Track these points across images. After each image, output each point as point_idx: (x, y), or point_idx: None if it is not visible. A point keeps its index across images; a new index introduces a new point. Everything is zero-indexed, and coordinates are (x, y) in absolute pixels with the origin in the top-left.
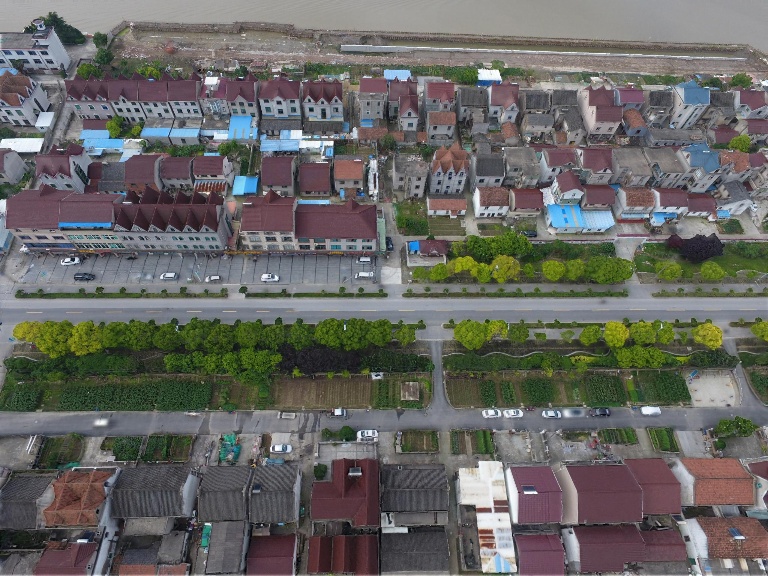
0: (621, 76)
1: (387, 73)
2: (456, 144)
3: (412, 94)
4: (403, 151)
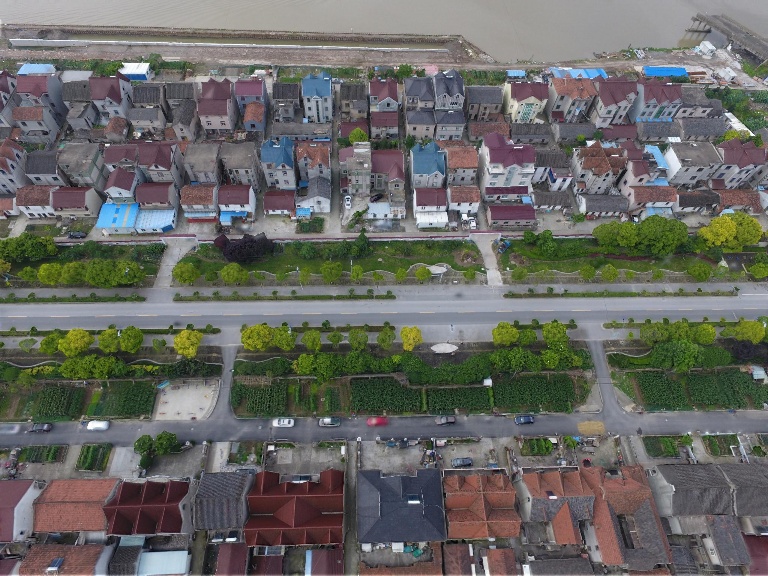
0: (294, 69)
1: (24, 67)
2: (5, 140)
3: (2, 88)
4: None
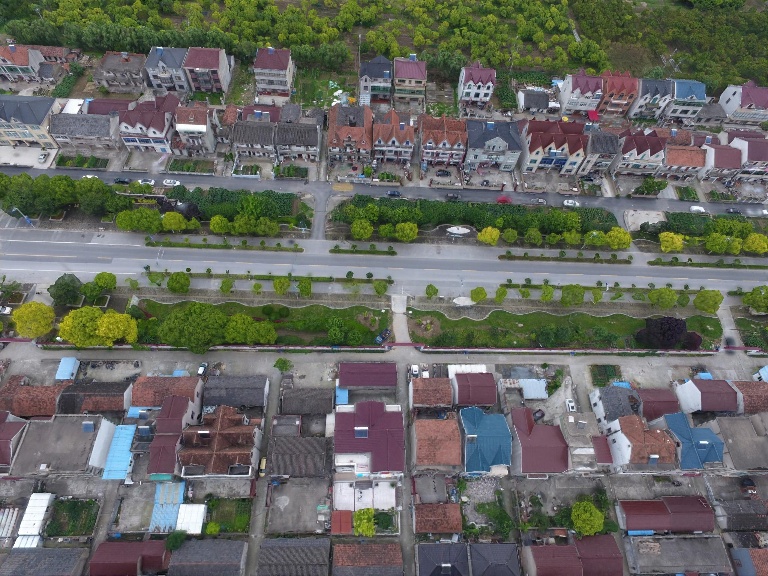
0: None
1: None
2: None
3: None
4: None
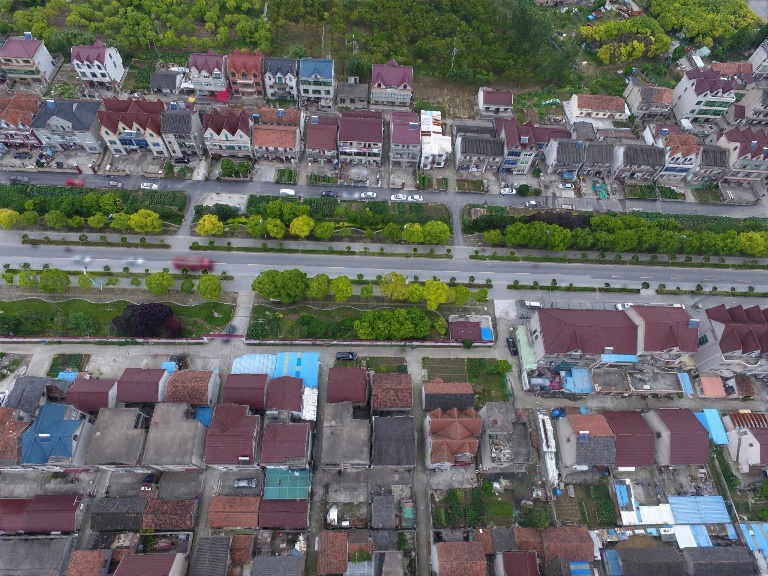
0: None
1: None
2: None
3: None
4: (509, 517)
